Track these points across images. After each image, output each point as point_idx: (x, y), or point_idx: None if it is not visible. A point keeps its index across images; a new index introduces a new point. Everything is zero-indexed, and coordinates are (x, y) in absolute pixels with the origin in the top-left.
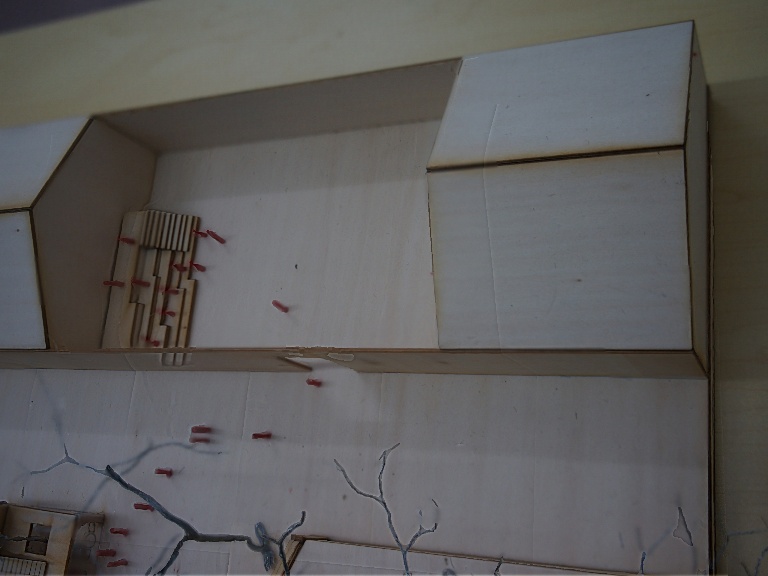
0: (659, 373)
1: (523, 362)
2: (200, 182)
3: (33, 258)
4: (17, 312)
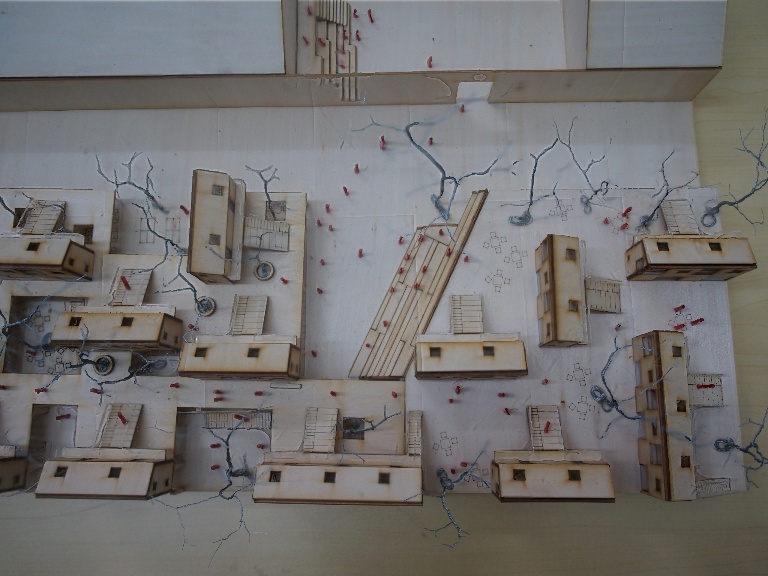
0: (673, 96)
1: (617, 84)
2: None
3: (281, 4)
4: (261, 45)
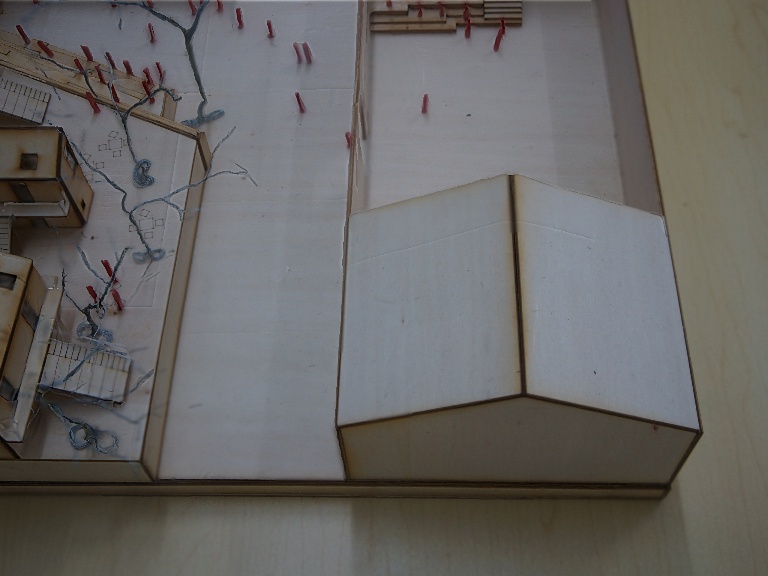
0: None
1: None
2: (561, 21)
3: None
4: None
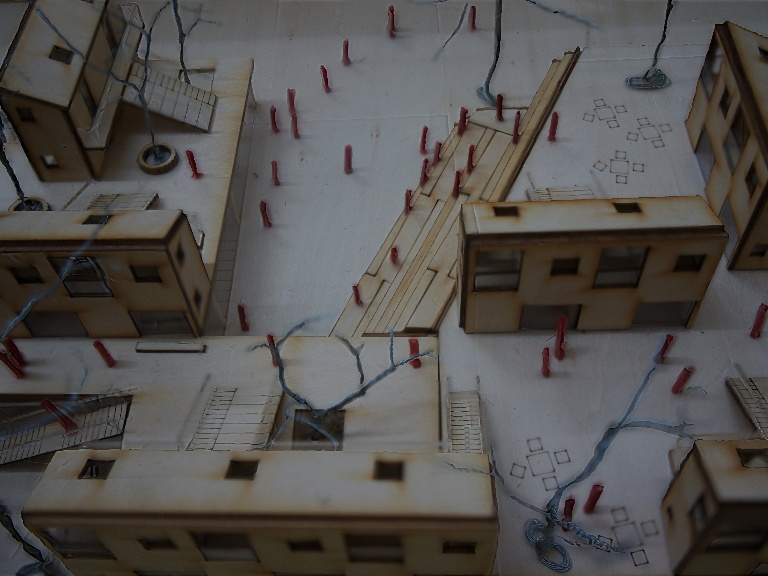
0: None
1: None
2: None
3: None
4: None
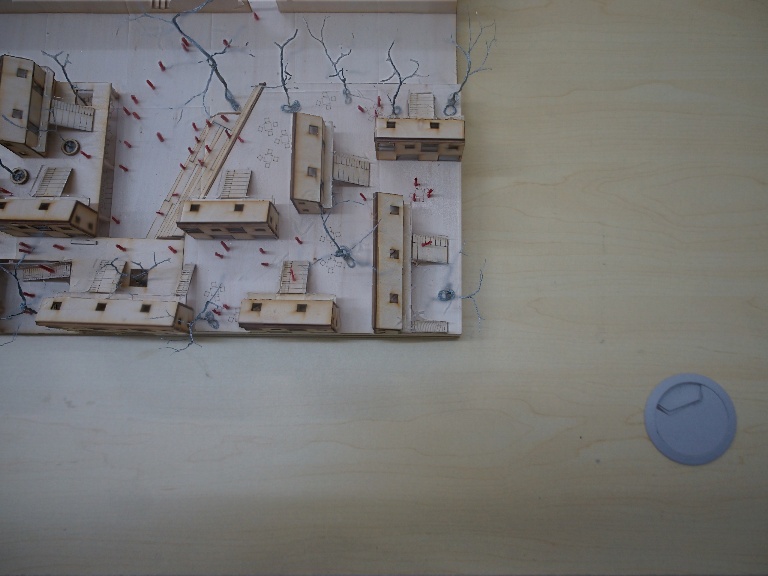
0: (437, 8)
1: None
2: None
3: None
4: None
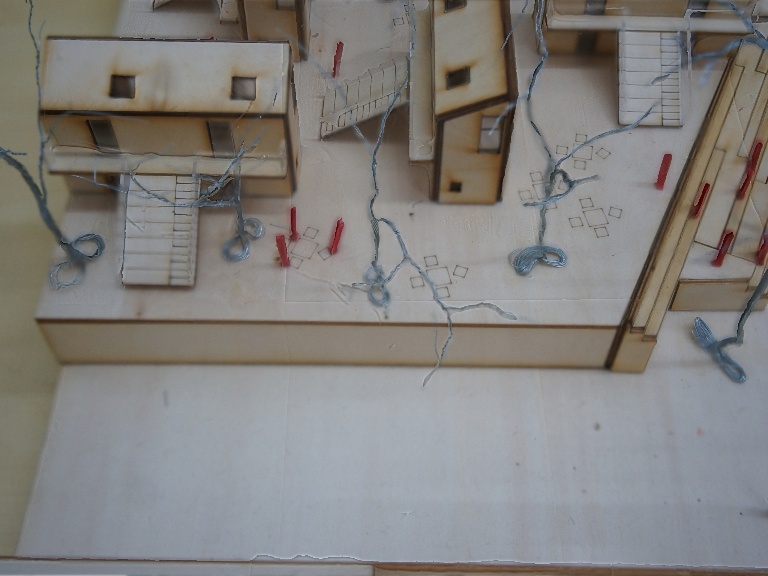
0: None
1: None
2: None
3: None
4: None
